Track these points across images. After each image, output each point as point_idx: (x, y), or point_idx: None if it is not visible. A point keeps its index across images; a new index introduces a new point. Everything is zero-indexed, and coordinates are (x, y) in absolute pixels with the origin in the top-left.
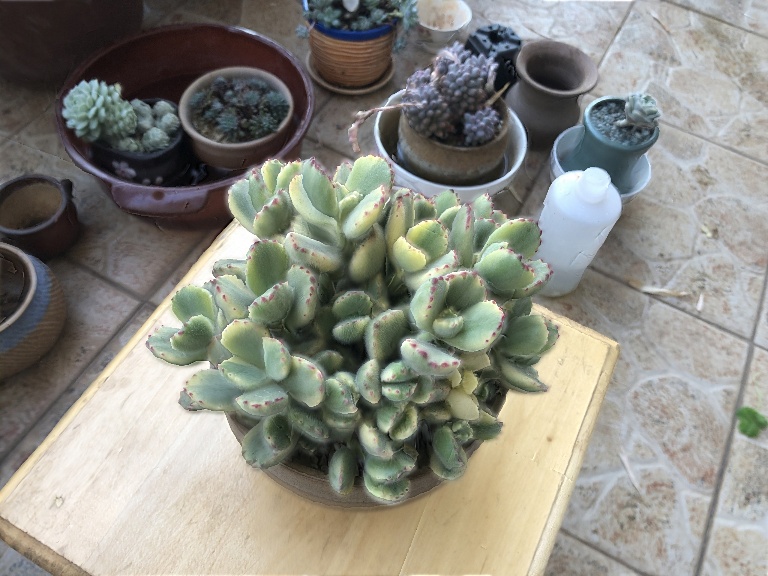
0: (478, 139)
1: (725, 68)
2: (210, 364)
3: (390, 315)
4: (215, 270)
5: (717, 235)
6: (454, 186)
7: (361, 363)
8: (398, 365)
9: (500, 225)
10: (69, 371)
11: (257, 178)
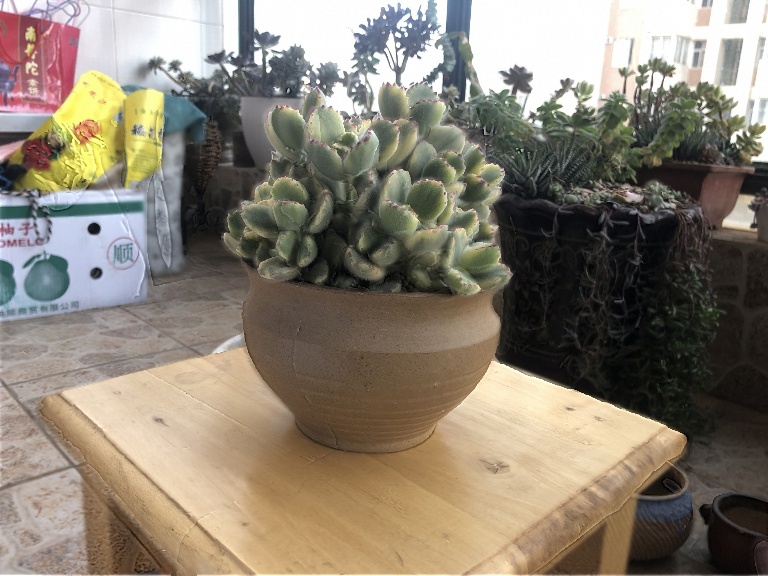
0: None
1: None
2: None
3: None
4: None
5: None
6: None
7: None
8: None
9: (394, 170)
10: (580, 569)
11: None
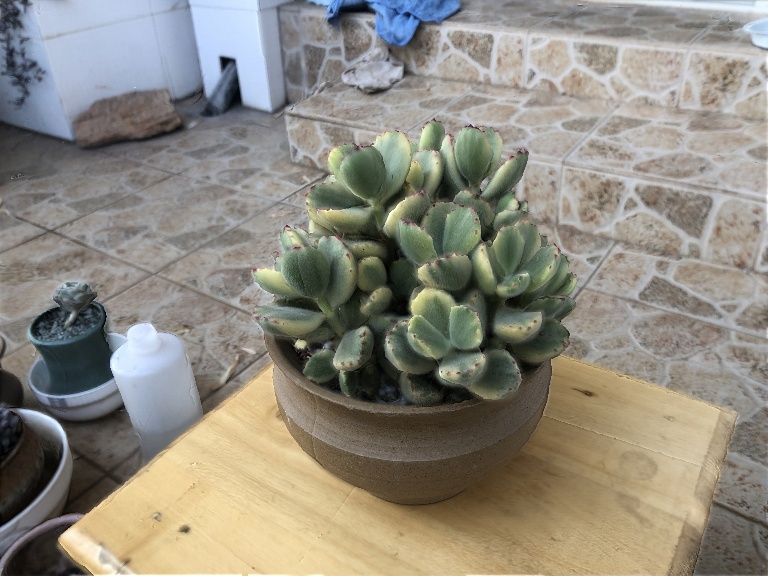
0: (15, 430)
1: (19, 281)
2: (444, 409)
3: (467, 191)
4: (362, 350)
5: (189, 327)
6: (49, 483)
7: (494, 232)
8: (506, 198)
9: None
10: None
11: (305, 245)
